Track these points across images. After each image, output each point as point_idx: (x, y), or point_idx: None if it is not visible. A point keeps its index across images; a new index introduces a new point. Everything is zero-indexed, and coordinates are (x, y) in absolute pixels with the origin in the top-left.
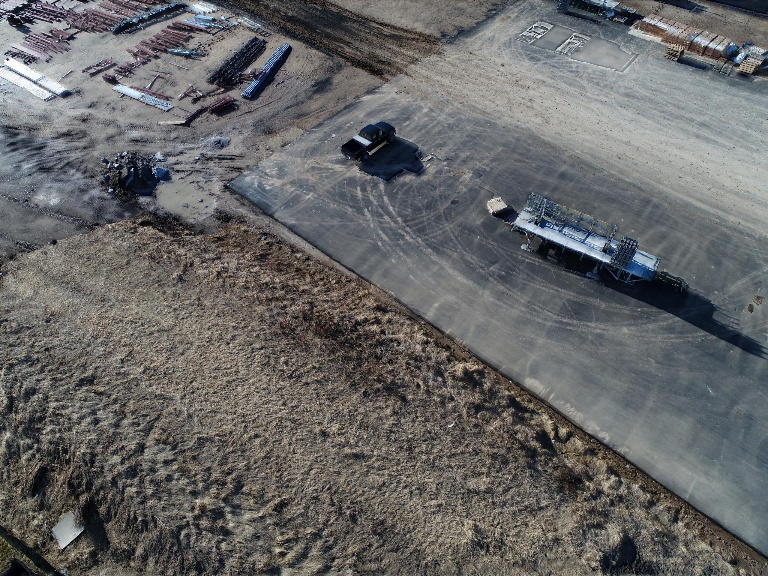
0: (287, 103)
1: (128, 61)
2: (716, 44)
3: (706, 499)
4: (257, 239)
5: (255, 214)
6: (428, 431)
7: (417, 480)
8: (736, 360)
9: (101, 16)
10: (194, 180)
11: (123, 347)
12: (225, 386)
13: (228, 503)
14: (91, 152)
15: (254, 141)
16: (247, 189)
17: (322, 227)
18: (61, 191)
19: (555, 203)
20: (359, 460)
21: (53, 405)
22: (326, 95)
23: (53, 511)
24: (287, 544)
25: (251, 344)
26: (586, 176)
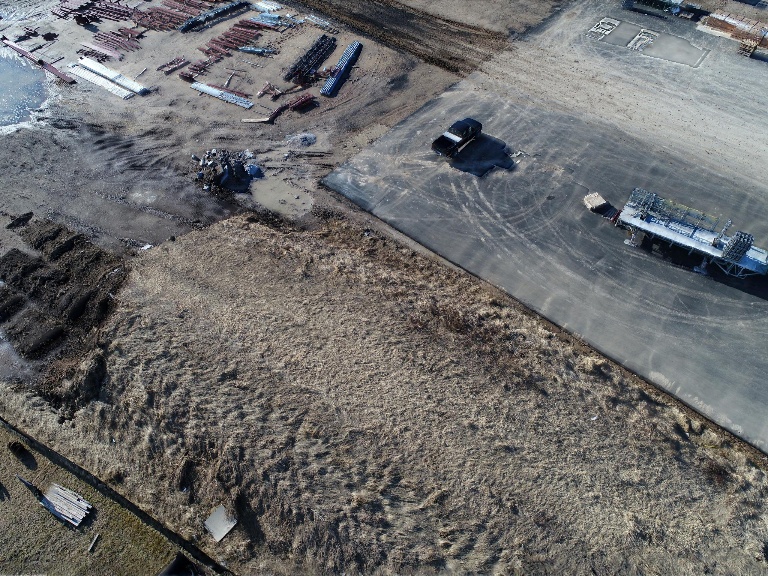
0: (366, 100)
1: (201, 59)
2: None
3: None
4: (360, 235)
5: (353, 210)
6: (574, 424)
7: (571, 472)
8: None
9: (167, 14)
10: (287, 177)
11: (261, 342)
12: (368, 380)
13: (386, 495)
14: (180, 150)
15: (340, 138)
16: (341, 186)
17: (422, 223)
18: (156, 188)
19: (661, 198)
20: (511, 453)
21: (196, 400)
22: (404, 92)
23: (203, 504)
24: (451, 536)
25: (386, 339)
26: (678, 171)
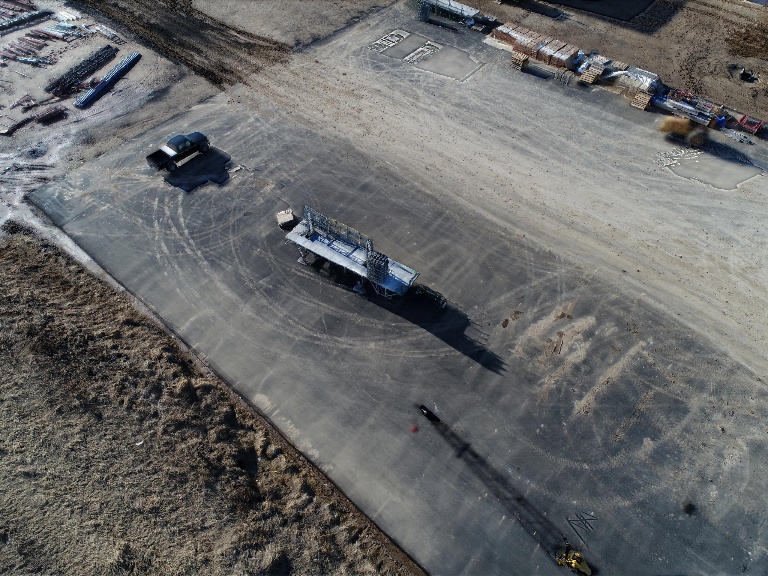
0: (117, 112)
1: None
2: (562, 53)
3: (393, 519)
4: (37, 251)
5: (45, 225)
6: (111, 449)
7: (83, 499)
8: (472, 376)
9: None
10: None
11: None
12: None
13: None
14: None
15: (70, 151)
16: (45, 200)
17: (107, 239)
18: None
19: (325, 216)
20: (29, 479)
21: None
22: (159, 104)
23: None
24: None
25: None
26: (388, 188)
